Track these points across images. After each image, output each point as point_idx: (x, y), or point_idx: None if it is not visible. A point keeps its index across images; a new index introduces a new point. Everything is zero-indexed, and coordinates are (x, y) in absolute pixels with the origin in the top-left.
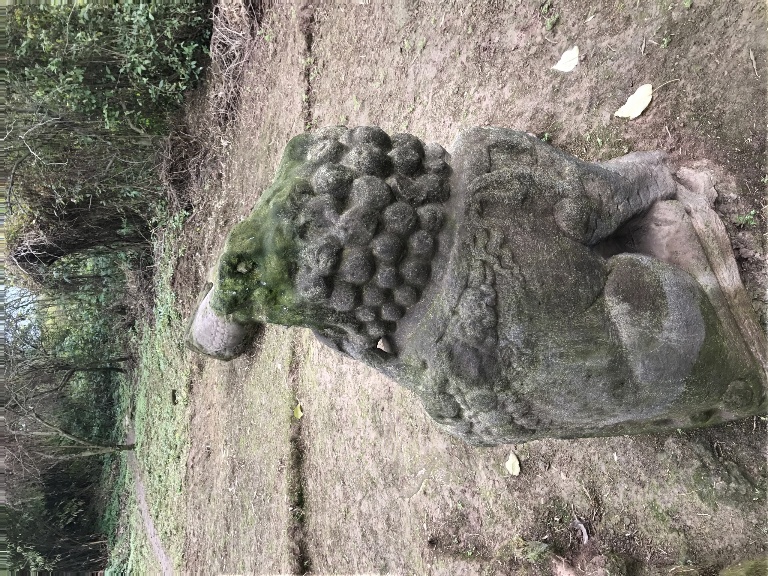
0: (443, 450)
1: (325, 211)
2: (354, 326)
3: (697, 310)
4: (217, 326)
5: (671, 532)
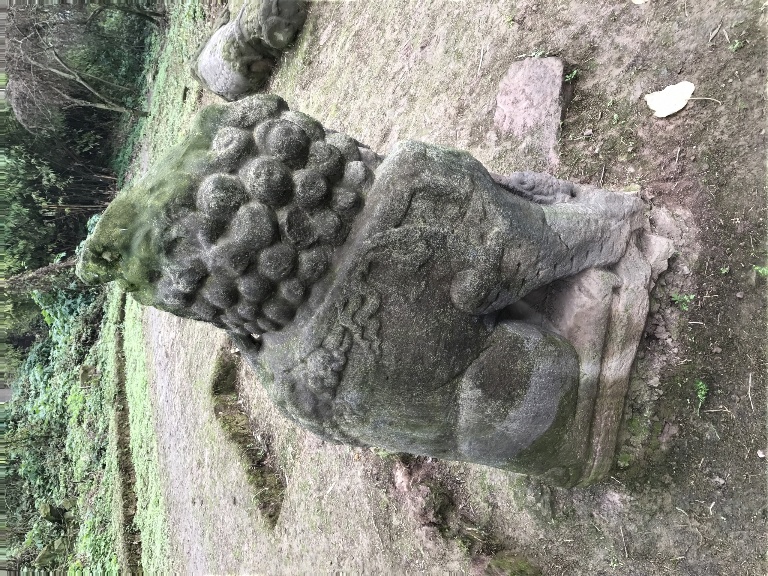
0: None
1: (198, 235)
2: (216, 325)
3: (556, 401)
4: (222, 69)
5: (484, 502)
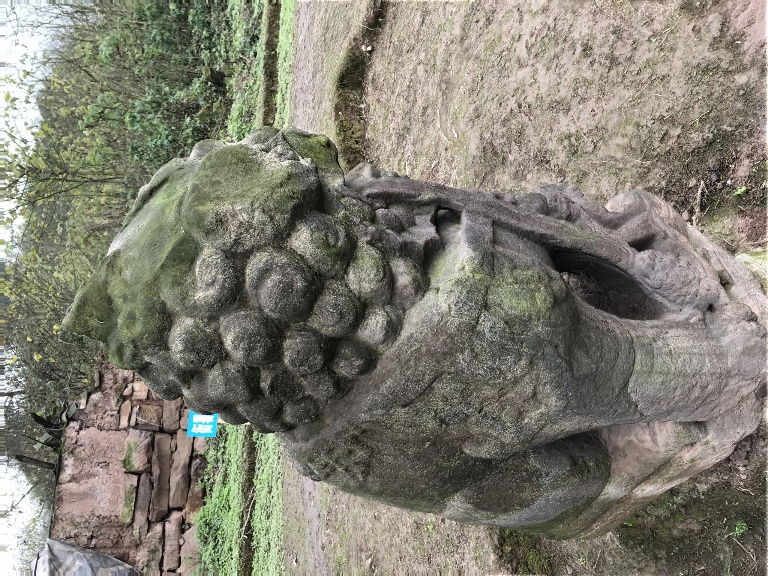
0: (471, 153)
1: None
2: None
3: (560, 511)
4: None
5: None
